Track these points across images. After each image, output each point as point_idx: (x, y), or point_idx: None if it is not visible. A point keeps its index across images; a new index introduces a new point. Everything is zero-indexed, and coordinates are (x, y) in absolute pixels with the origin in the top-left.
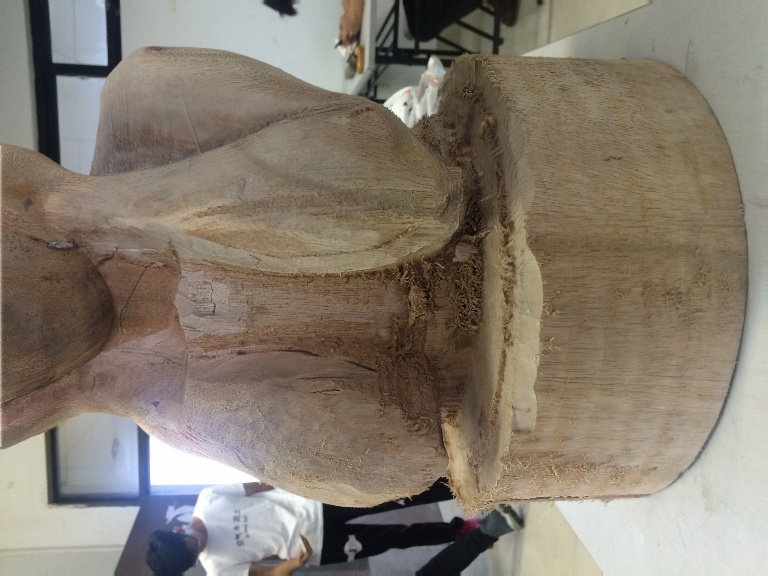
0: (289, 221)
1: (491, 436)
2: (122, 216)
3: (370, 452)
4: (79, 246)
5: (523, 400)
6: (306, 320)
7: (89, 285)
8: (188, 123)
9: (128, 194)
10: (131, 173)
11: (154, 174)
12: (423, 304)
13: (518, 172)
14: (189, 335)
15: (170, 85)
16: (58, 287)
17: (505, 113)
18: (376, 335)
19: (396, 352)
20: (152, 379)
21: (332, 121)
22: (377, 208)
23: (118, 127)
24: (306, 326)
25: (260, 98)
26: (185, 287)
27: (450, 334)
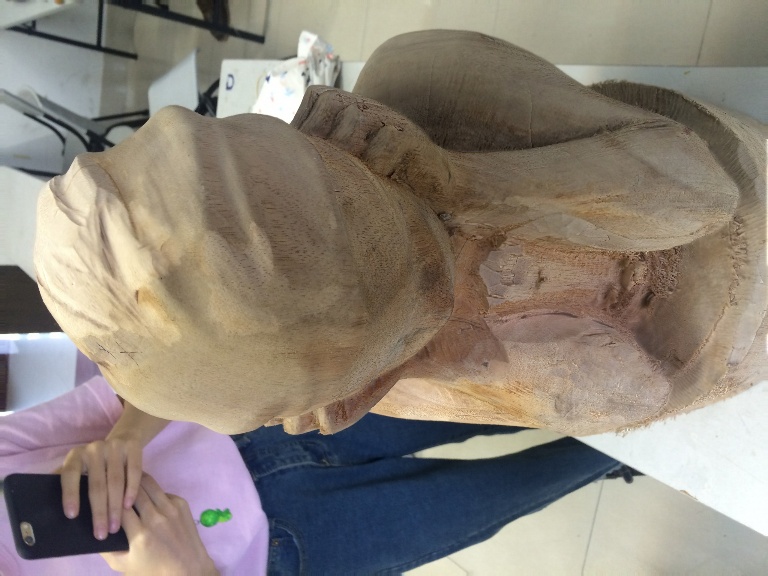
0: (660, 211)
1: (684, 371)
2: (522, 195)
3: (641, 389)
4: None
5: (742, 342)
6: (566, 288)
7: None
8: (529, 113)
9: (526, 176)
10: (505, 155)
11: (537, 159)
12: (643, 275)
13: (756, 186)
14: (492, 302)
15: (516, 76)
16: None
17: (731, 141)
18: (595, 300)
19: (612, 313)
20: (469, 343)
21: (680, 136)
22: (711, 206)
23: (440, 103)
24: (564, 293)
25: (597, 103)
26: (497, 259)
27: (641, 298)
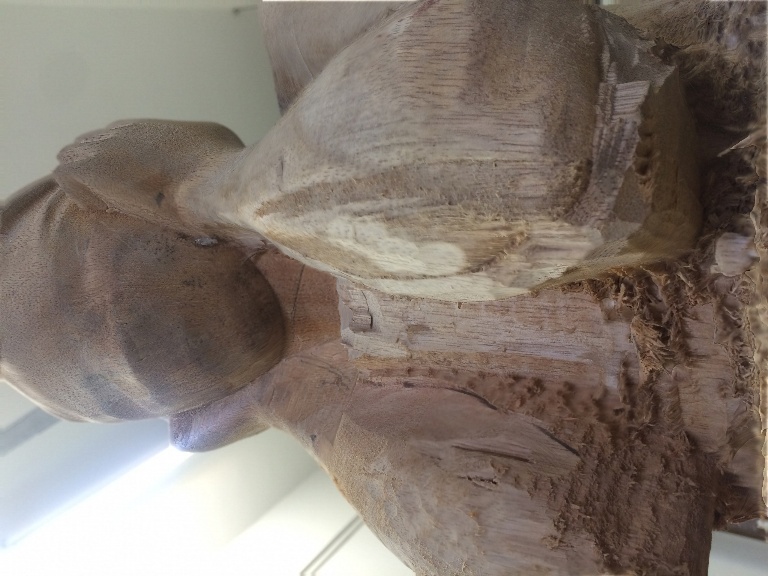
0: (336, 225)
1: None
2: (223, 211)
3: None
4: (228, 241)
5: None
6: (483, 349)
7: (239, 288)
8: (305, 65)
9: (225, 182)
10: None
11: (250, 150)
12: (658, 350)
13: None
14: (352, 352)
15: (286, 14)
16: (201, 293)
17: None
18: (599, 384)
19: (626, 422)
20: (319, 402)
21: (386, 32)
22: (441, 201)
23: None
24: (485, 358)
25: (354, 7)
26: (339, 290)
27: (732, 407)
